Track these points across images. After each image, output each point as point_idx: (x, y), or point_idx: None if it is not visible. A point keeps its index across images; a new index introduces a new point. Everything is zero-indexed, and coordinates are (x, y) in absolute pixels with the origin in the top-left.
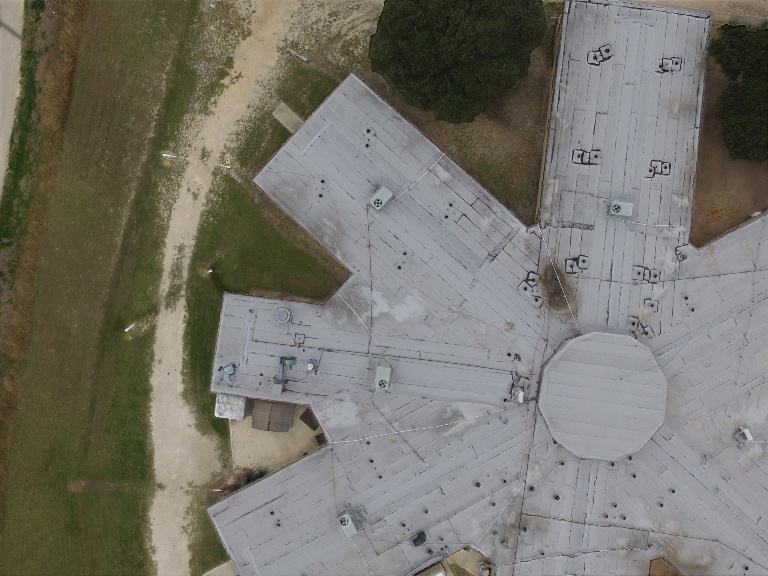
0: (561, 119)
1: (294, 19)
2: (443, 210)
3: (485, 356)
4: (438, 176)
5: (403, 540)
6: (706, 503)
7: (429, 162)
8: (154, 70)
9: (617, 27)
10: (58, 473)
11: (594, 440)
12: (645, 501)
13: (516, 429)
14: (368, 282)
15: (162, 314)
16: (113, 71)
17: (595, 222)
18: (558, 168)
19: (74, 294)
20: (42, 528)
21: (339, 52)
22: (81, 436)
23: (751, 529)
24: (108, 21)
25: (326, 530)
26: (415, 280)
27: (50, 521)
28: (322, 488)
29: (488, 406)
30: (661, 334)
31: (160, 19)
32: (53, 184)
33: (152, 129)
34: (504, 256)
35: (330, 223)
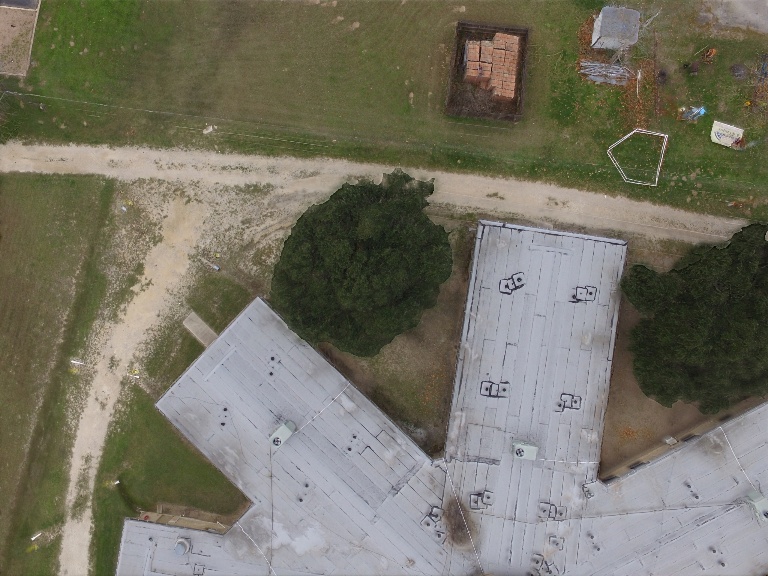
0: (470, 349)
1: (206, 225)
2: (347, 441)
3: None
4: (343, 406)
5: None
6: None
7: (334, 391)
8: (64, 274)
9: (531, 254)
10: None
11: None
12: None
13: None
14: (269, 513)
15: (68, 525)
16: (22, 274)
17: (501, 457)
18: (465, 400)
19: None
20: None
21: (251, 261)
22: None
23: None
24: (18, 222)
25: None
26: (317, 512)
27: None
28: None
29: None
30: (565, 573)
31: (70, 222)
32: None
33: (61, 335)
34: (408, 490)
35: (232, 451)
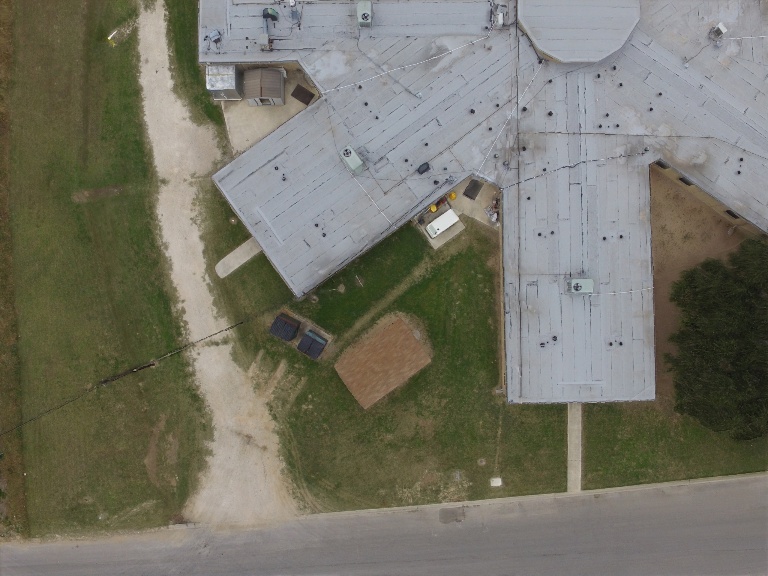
0: None
1: None
2: None
3: None
4: None
5: (408, 175)
6: (693, 100)
7: None
8: None
9: None
10: (60, 186)
11: (576, 43)
12: (635, 108)
13: (501, 52)
14: None
15: (142, 16)
16: None
17: None
18: None
19: (53, 11)
20: (52, 243)
21: None
22: (78, 147)
23: (739, 119)
24: None
25: (331, 175)
26: None
27: (59, 234)
28: (322, 138)
29: (471, 37)
30: None
31: None
32: None
33: None
34: None
35: None
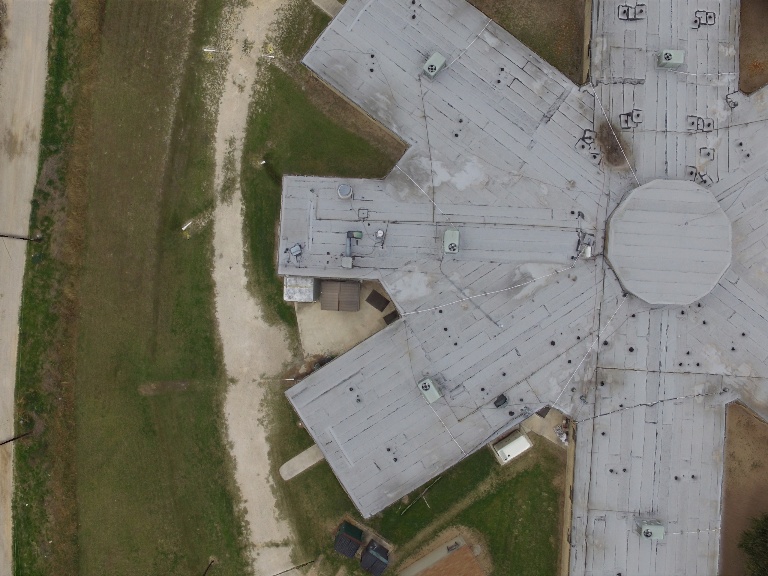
0: None
1: None
2: (495, 75)
3: (549, 216)
4: (487, 42)
5: (483, 404)
6: None
7: (477, 29)
8: None
9: None
10: (127, 377)
11: (664, 286)
12: (716, 346)
13: (585, 285)
14: (426, 152)
15: (219, 209)
16: None
17: (646, 76)
18: (605, 25)
19: (127, 197)
20: (116, 434)
21: None
22: (147, 339)
23: None
24: None
25: (406, 400)
26: (473, 147)
27: (123, 426)
28: (398, 361)
29: (556, 265)
30: (719, 181)
31: None
32: (96, 88)
33: (191, 25)
34: (559, 116)
35: (383, 97)
